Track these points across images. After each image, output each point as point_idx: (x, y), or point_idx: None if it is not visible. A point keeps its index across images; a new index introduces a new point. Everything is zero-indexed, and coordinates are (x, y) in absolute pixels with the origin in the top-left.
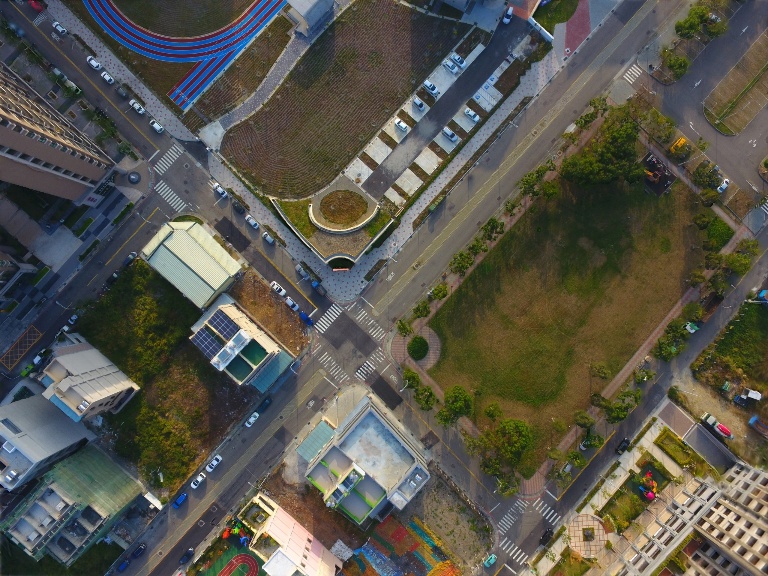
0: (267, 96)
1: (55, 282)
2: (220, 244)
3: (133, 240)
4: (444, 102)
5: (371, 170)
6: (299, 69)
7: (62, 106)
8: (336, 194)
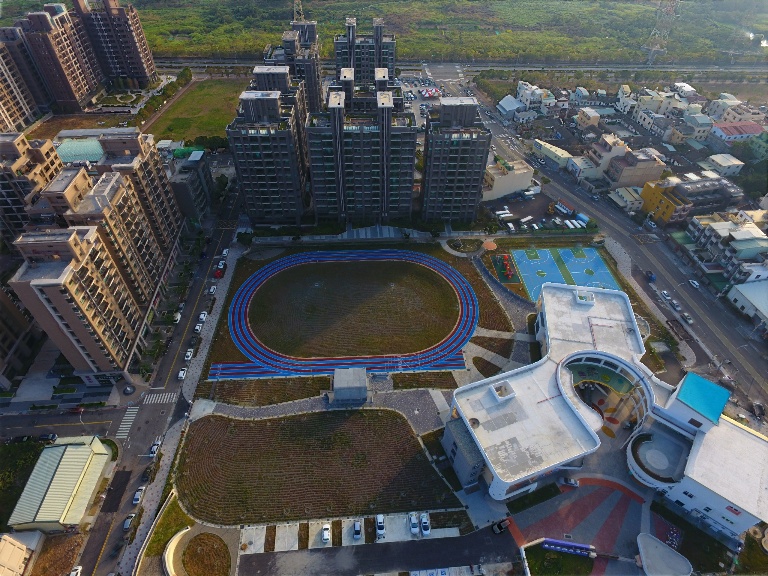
0: (263, 416)
1: (1, 407)
2: (101, 489)
3: (70, 427)
4: (381, 550)
5: (263, 549)
6: (302, 418)
7: (160, 322)
8: (216, 540)
